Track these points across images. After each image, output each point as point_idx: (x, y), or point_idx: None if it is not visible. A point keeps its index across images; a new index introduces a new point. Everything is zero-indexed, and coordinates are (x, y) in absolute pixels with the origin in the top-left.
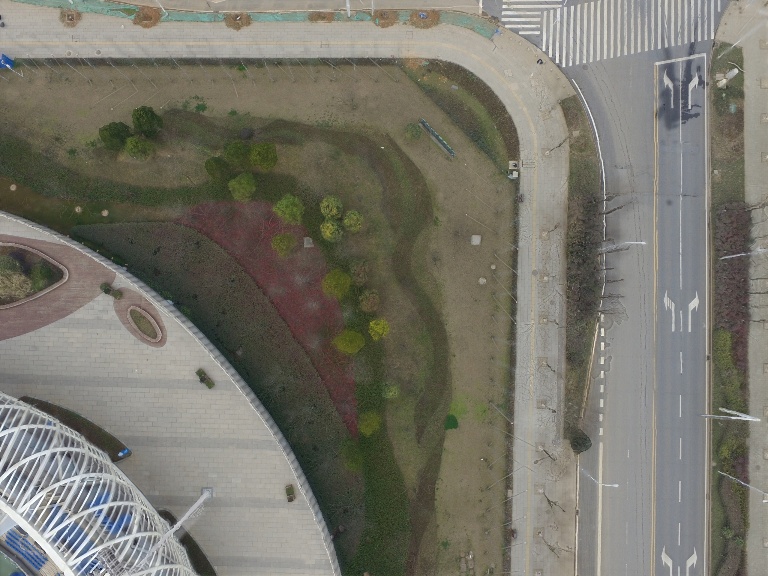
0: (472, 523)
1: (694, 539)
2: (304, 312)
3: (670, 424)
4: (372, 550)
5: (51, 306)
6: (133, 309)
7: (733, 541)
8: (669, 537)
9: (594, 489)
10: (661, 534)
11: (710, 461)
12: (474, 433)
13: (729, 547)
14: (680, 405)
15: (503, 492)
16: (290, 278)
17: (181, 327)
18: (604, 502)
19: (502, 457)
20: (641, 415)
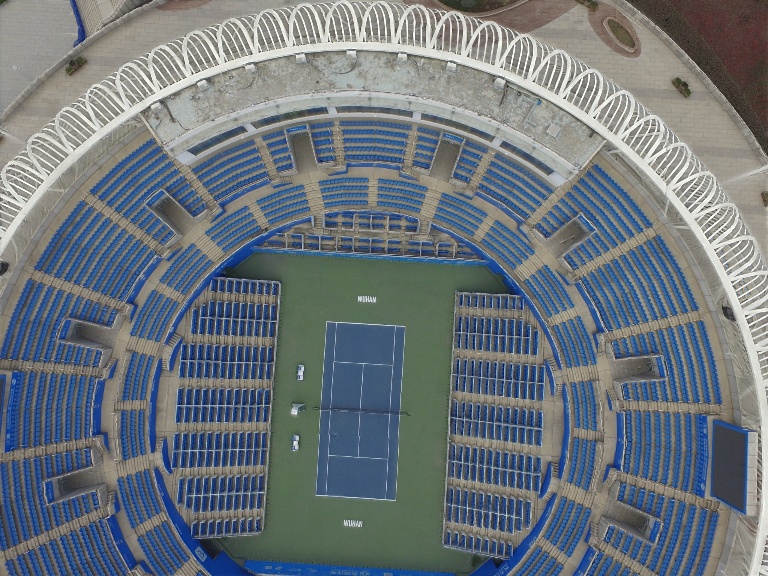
0: None
1: None
2: (740, 50)
3: None
4: None
5: (527, 16)
6: (611, 19)
7: None
8: None
9: None
10: None
11: None
12: None
13: None
14: None
15: None
16: (725, 17)
17: (655, 39)
18: None
19: None
20: None
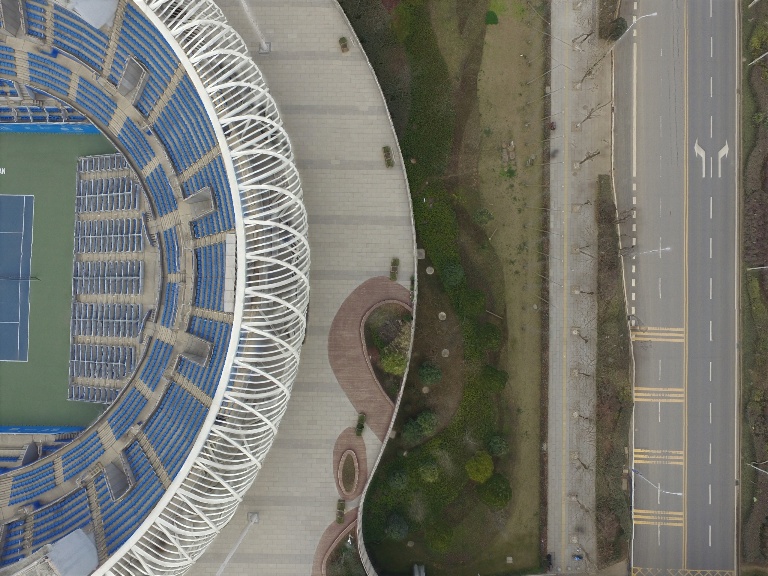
0: (513, 115)
1: (725, 131)
2: None
3: (701, 23)
4: (418, 135)
5: None
6: None
7: (764, 124)
8: (701, 130)
9: (629, 87)
10: (694, 127)
11: (740, 57)
12: (513, 30)
13: (760, 131)
14: (711, 5)
15: (542, 88)
16: None
17: None
18: (639, 98)
19: (540, 56)
20: (673, 16)
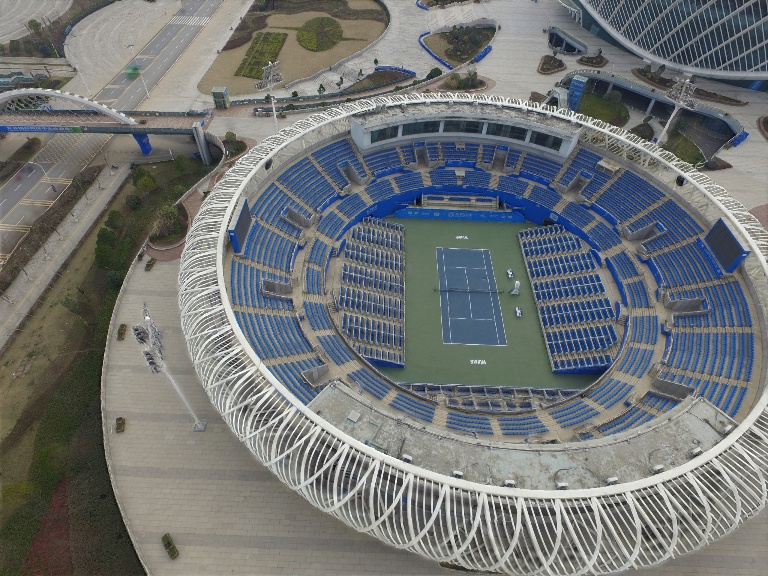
0: None
1: None
2: None
3: None
4: (96, 380)
5: None
6: None
7: None
8: None
9: None
10: None
11: None
12: None
13: None
14: None
15: None
16: None
17: None
18: None
19: None
20: None
